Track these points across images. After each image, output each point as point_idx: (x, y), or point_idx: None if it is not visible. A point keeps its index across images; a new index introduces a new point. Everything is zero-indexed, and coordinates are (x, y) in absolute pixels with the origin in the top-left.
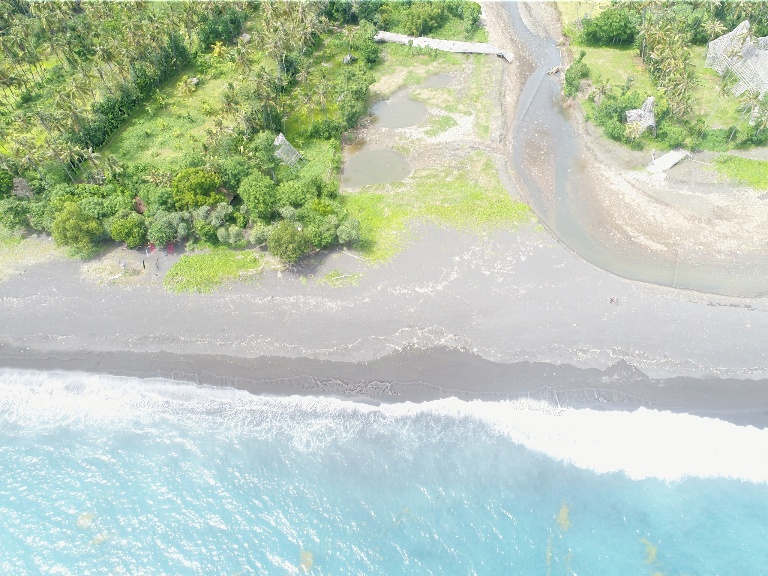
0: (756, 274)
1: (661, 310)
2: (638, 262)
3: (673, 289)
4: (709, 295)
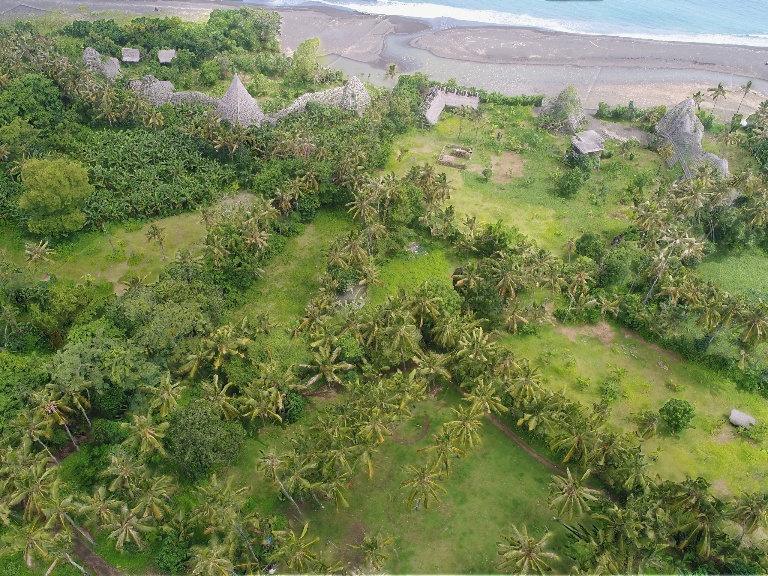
0: (687, 76)
1: (741, 61)
2: (755, 84)
3: (733, 73)
4: (714, 70)
